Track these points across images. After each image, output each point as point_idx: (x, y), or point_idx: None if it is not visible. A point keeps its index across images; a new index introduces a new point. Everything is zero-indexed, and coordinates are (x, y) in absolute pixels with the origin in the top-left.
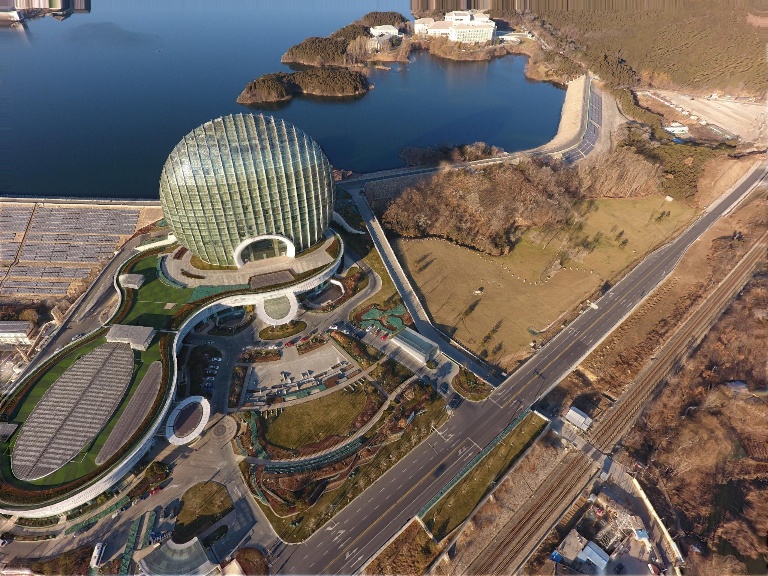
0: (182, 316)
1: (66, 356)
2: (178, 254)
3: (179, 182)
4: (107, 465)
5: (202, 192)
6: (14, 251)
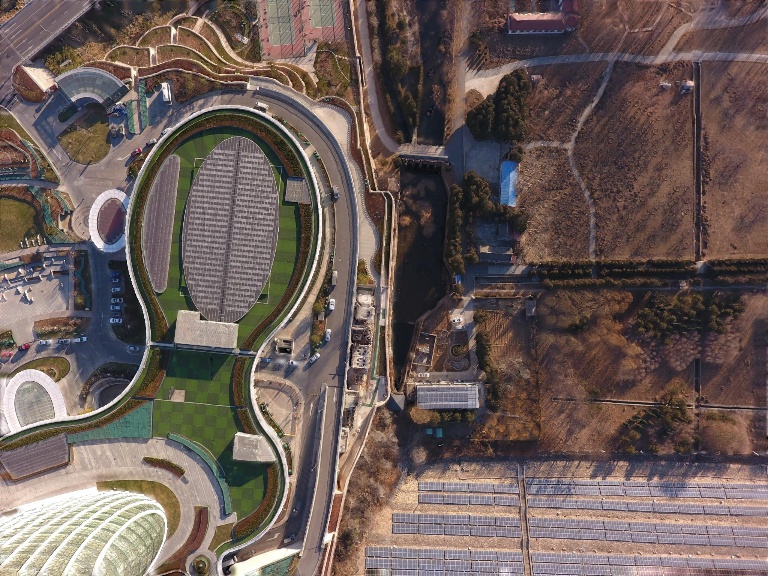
0: (151, 373)
1: (281, 300)
2: (203, 521)
3: (33, 575)
4: (163, 153)
5: (3, 559)
6: (538, 572)
